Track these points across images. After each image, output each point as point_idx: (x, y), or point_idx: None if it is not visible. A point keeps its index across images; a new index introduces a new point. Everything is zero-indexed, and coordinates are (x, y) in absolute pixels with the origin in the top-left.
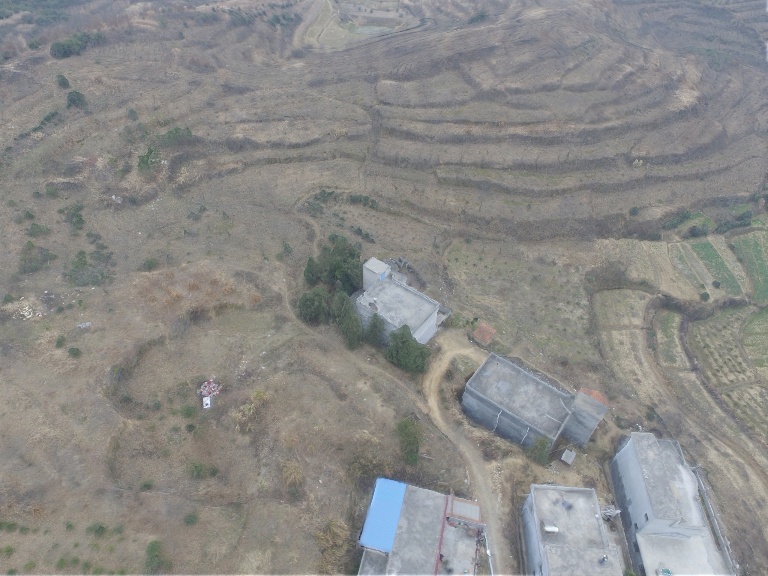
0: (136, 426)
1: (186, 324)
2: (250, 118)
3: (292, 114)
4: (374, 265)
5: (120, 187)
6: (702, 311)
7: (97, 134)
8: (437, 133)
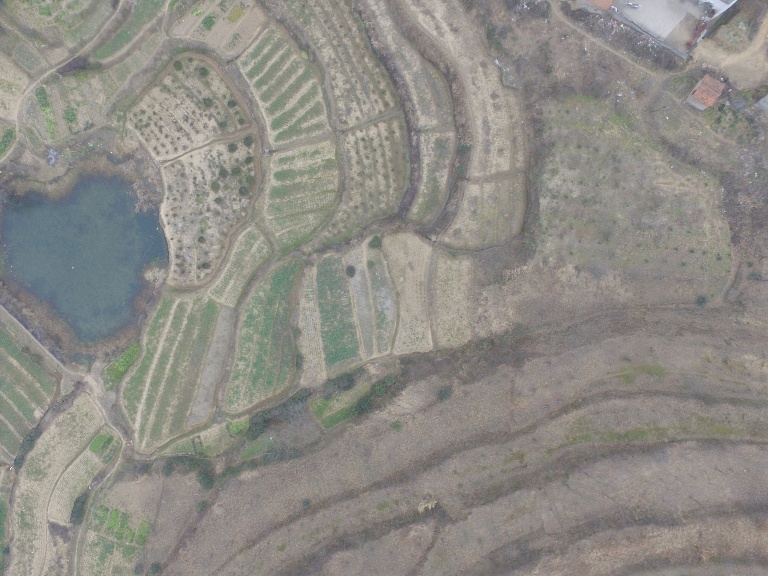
0: None
1: None
2: None
3: None
4: None
5: None
6: None
7: None
8: None
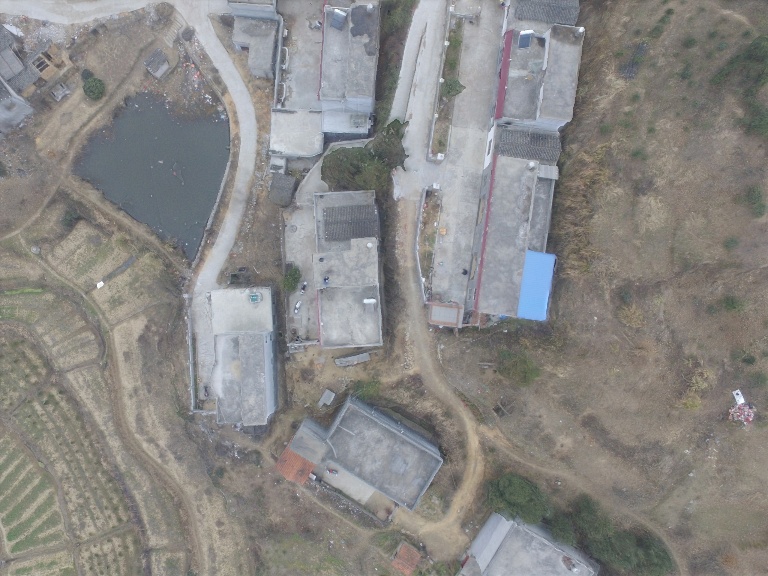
0: None
1: None
2: None
3: None
4: None
5: None
6: None
7: None
8: None
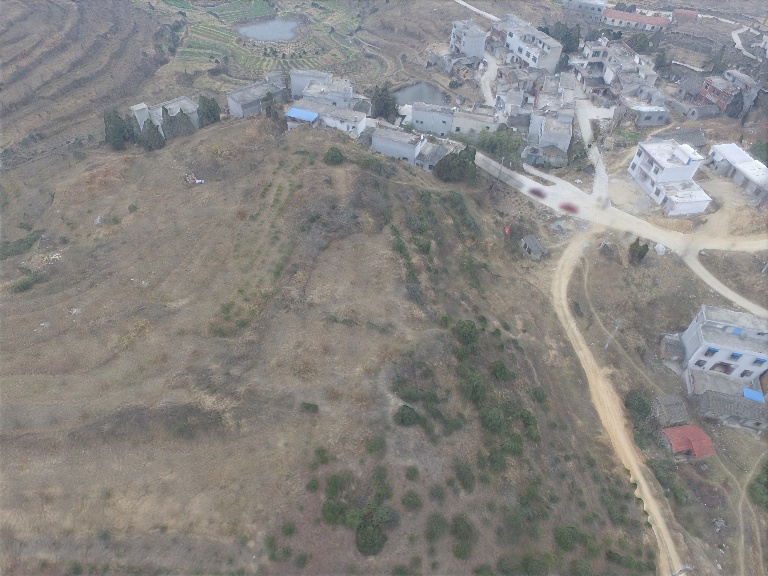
0: None
1: None
2: None
3: None
4: (137, 107)
5: None
6: (224, 67)
7: None
8: None
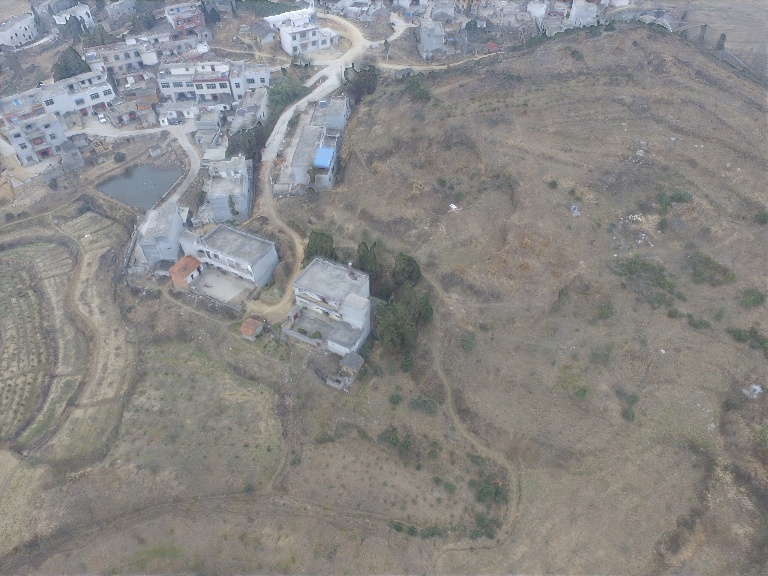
0: (477, 169)
1: None
2: None
3: None
4: (359, 302)
5: None
6: None
7: None
8: None
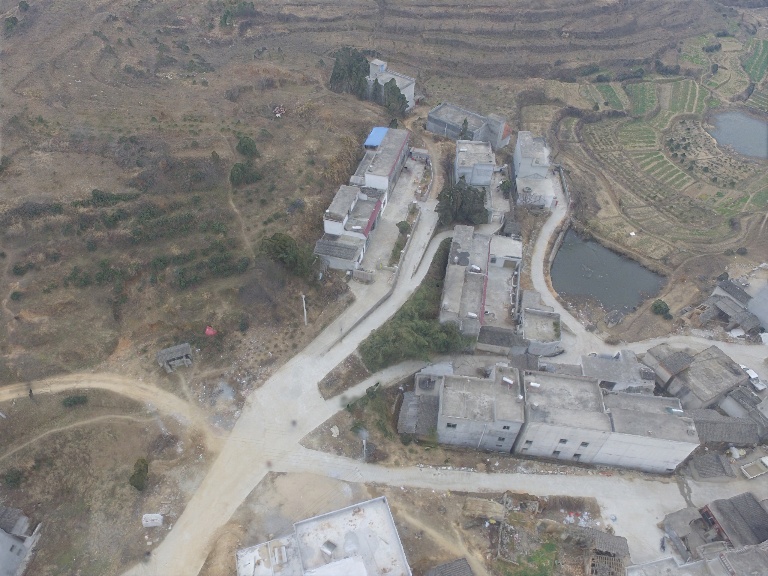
0: None
1: (263, 87)
2: (293, 3)
3: (322, 2)
4: (377, 62)
5: (208, 35)
6: (593, 116)
7: (190, 5)
8: (424, 12)
